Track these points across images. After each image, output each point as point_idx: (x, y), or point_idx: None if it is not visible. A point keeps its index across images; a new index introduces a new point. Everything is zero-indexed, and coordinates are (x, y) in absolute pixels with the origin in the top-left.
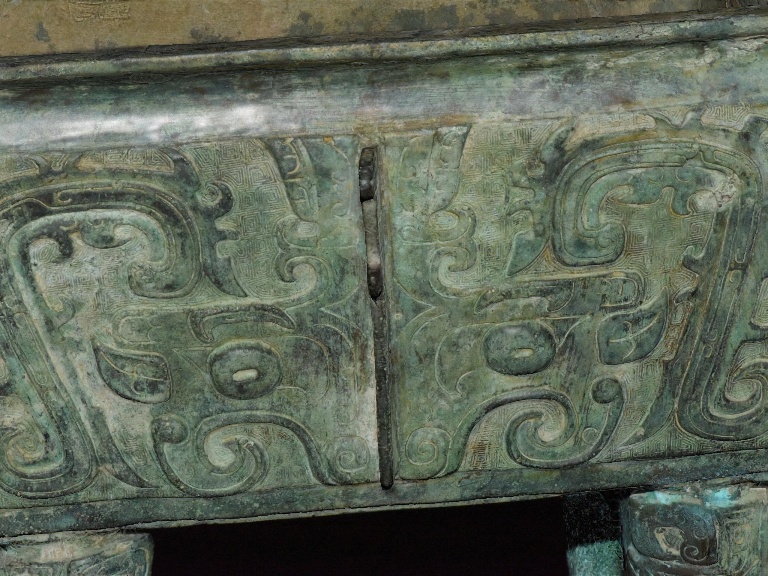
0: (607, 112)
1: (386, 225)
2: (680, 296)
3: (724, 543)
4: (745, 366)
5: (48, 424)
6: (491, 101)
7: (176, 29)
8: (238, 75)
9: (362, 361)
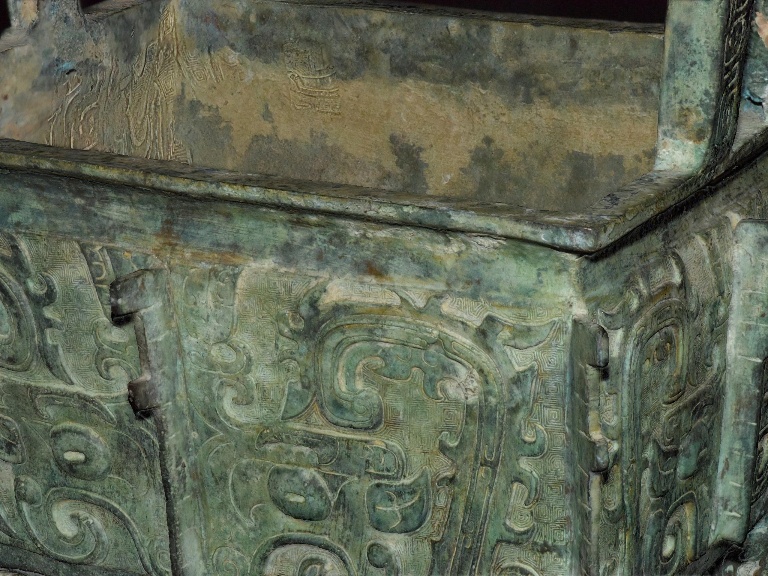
0: (360, 281)
1: (179, 346)
2: (440, 479)
3: None
4: (505, 566)
5: None
6: (266, 248)
7: (378, 132)
8: (64, 179)
9: None
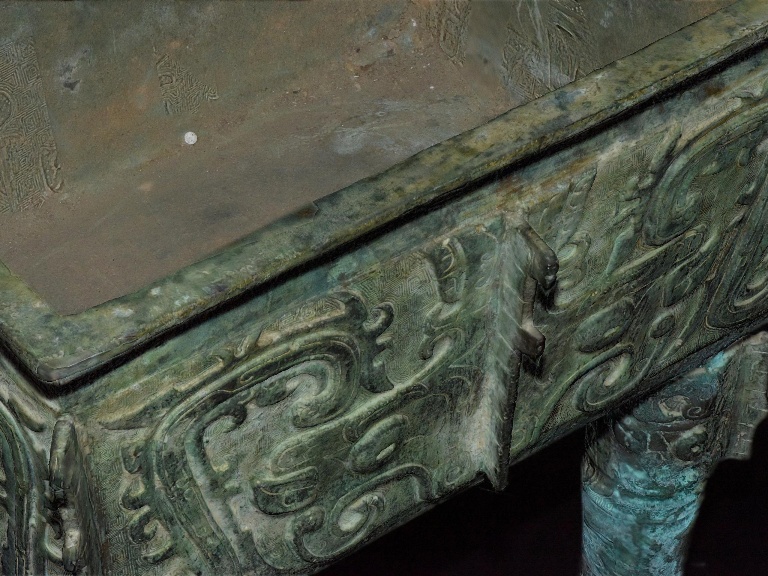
0: (704, 107)
1: None
2: (730, 227)
3: (720, 394)
4: (767, 259)
5: (201, 564)
6: (609, 134)
7: None
8: None
9: (476, 392)
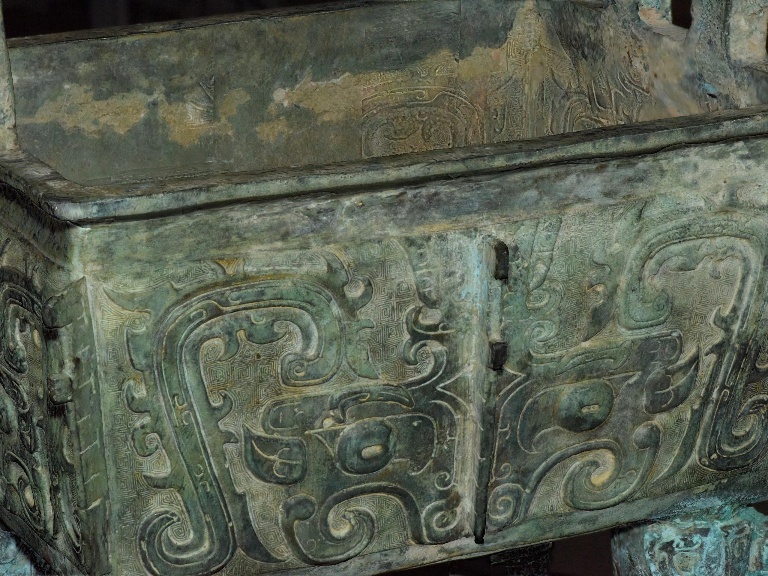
0: None
1: None
2: None
3: None
4: None
5: None
6: None
7: None
8: None
9: None
